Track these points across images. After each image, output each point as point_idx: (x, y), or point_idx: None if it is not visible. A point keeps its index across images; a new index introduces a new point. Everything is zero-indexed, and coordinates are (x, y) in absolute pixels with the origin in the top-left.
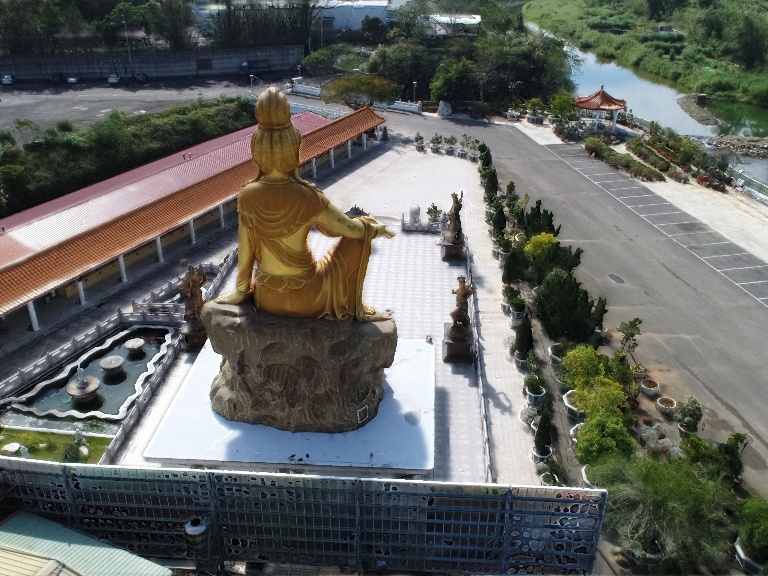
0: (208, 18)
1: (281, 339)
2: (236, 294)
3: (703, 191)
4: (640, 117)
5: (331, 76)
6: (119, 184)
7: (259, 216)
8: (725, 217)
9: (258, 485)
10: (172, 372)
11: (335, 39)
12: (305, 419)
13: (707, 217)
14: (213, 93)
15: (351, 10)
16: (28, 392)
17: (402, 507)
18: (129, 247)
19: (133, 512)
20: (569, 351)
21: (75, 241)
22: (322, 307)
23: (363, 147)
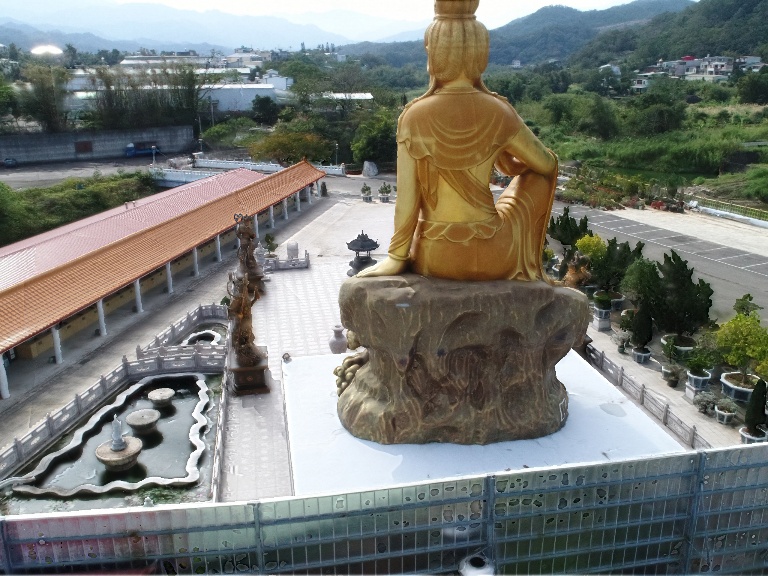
0: (84, 100)
1: (477, 307)
2: (391, 261)
3: (665, 214)
4: (562, 165)
5: (232, 151)
6: (59, 233)
7: (442, 138)
8: (704, 230)
9: (557, 487)
10: (233, 419)
11: (224, 120)
12: (499, 423)
13: (688, 231)
14: (104, 172)
15: (237, 92)
16: (32, 470)
17: (750, 488)
18: (112, 287)
19: (355, 572)
20: (685, 340)
21: (44, 280)
22: (513, 264)
23: (308, 201)
